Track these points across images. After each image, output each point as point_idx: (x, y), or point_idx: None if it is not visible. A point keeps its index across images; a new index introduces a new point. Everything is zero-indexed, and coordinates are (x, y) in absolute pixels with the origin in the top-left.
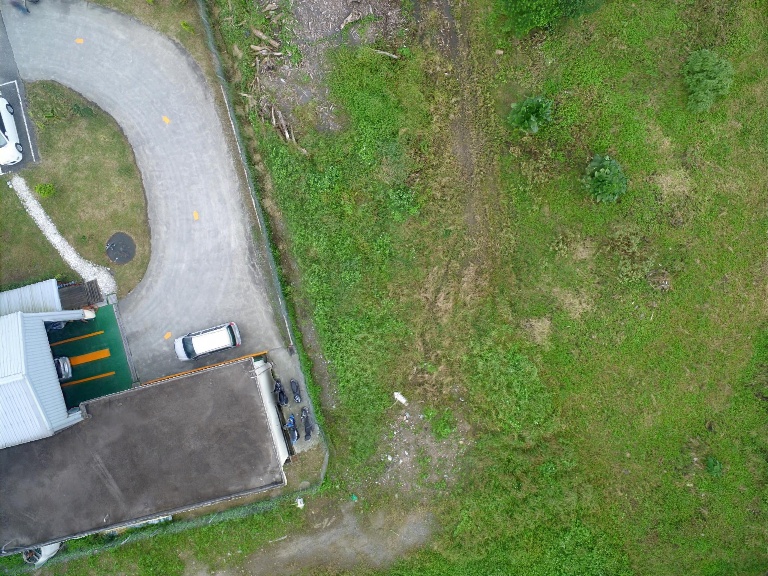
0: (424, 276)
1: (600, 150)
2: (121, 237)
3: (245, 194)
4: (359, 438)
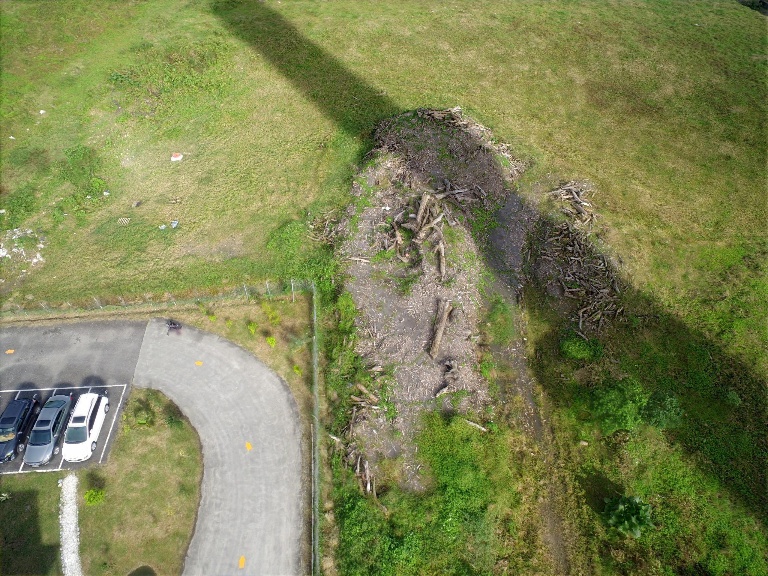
0: None
1: (716, 573)
2: (145, 573)
3: (305, 546)
4: None
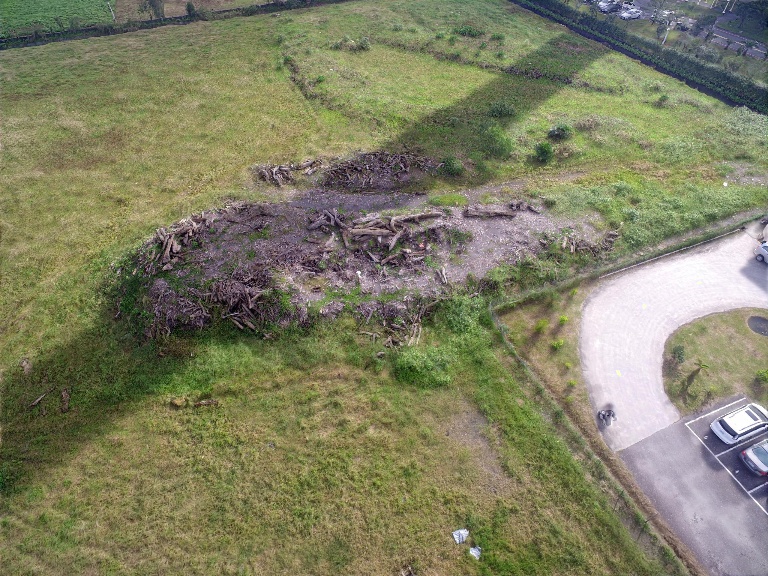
0: None
1: None
2: None
3: None
4: (765, 194)
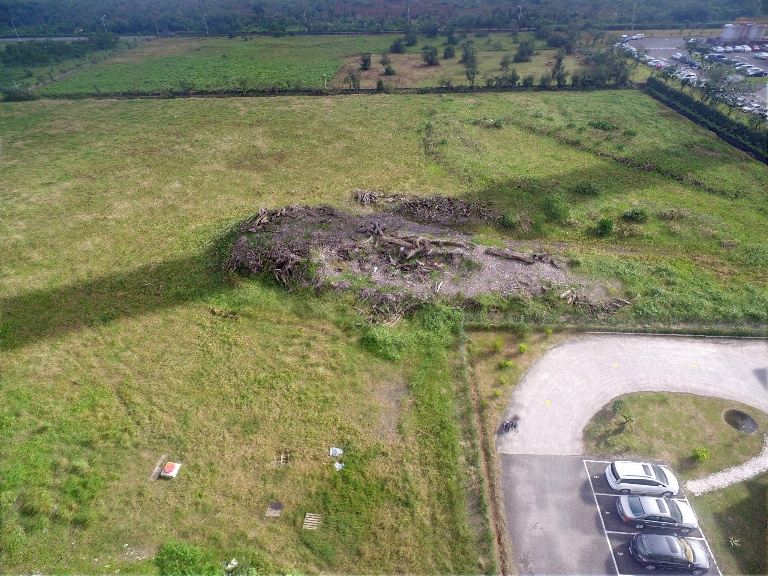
0: None
1: None
2: None
3: None
4: None
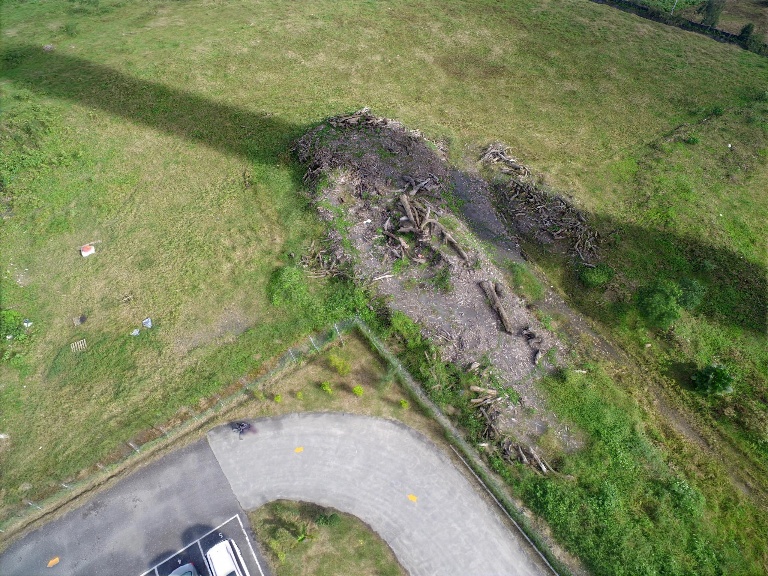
0: (762, 570)
1: None
2: None
3: (529, 550)
4: None
